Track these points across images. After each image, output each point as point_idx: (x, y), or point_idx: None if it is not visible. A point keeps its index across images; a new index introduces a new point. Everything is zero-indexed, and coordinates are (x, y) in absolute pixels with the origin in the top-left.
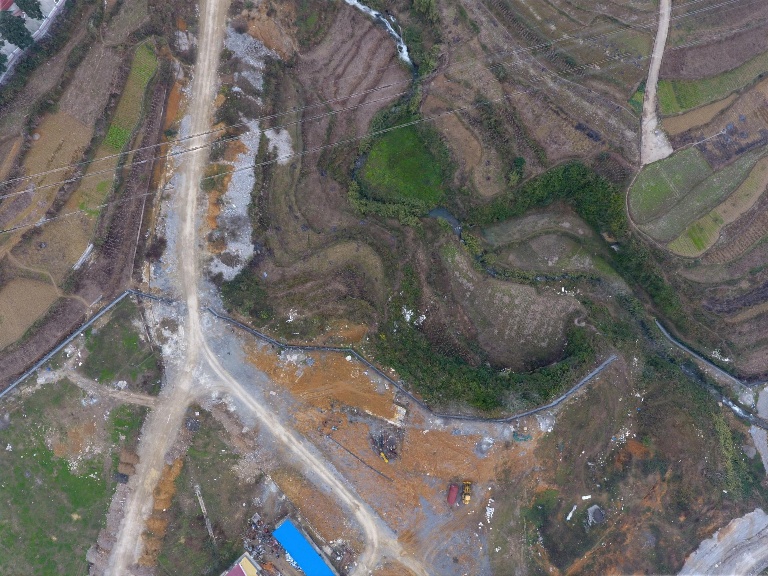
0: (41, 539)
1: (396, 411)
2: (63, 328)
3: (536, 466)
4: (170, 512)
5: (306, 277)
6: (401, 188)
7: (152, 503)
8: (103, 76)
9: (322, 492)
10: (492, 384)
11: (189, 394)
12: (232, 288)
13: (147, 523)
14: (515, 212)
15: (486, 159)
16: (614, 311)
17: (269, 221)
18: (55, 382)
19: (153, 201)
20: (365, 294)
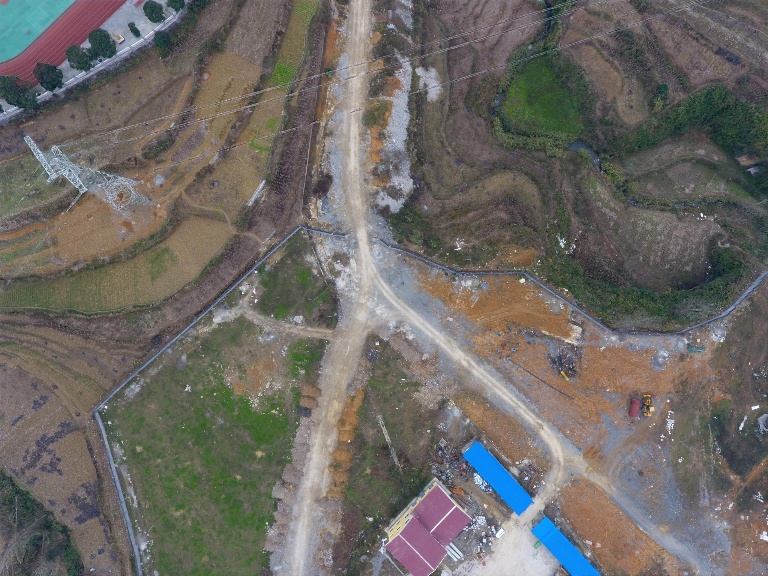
0: (225, 479)
1: (572, 330)
2: (238, 265)
3: (711, 376)
4: (354, 443)
5: (467, 208)
6: (541, 123)
7: (337, 435)
8: (268, 15)
9: (505, 414)
10: (660, 300)
11: (366, 325)
12: (399, 220)
13: (333, 455)
14: (657, 139)
15: (628, 88)
16: (751, 234)
17: (425, 156)
18: (232, 320)
19: (317, 138)
20: (527, 221)
